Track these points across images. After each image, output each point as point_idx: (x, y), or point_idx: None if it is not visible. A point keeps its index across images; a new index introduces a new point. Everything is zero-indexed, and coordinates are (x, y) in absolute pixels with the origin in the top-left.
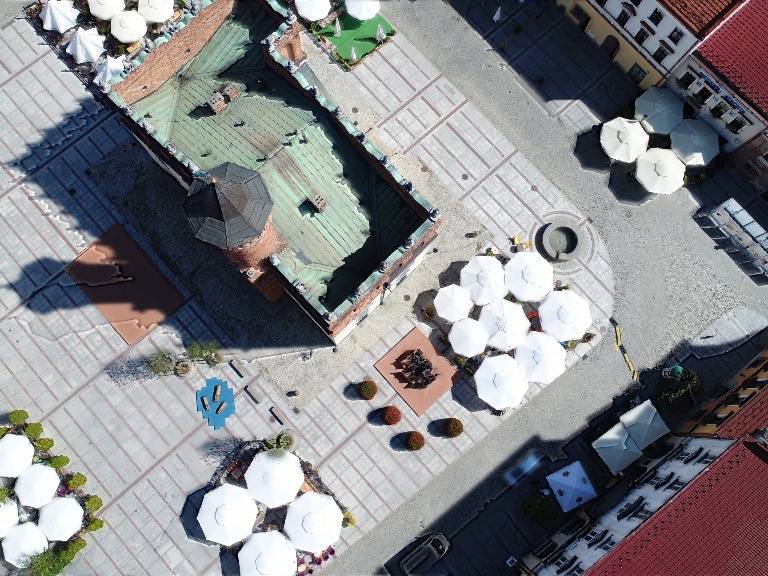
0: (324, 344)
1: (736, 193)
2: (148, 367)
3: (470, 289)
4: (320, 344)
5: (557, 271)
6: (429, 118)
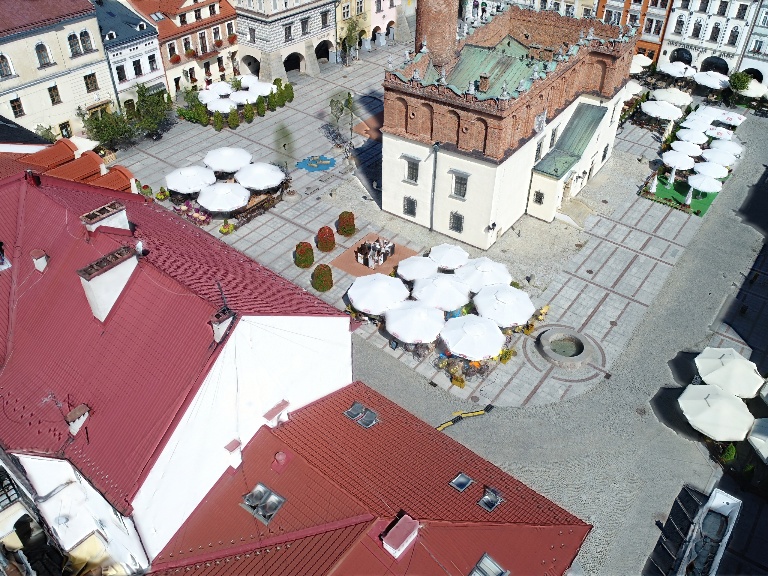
0: (381, 204)
1: (765, 542)
2: (336, 137)
3: (469, 262)
4: (380, 203)
5: (527, 350)
6: (633, 243)
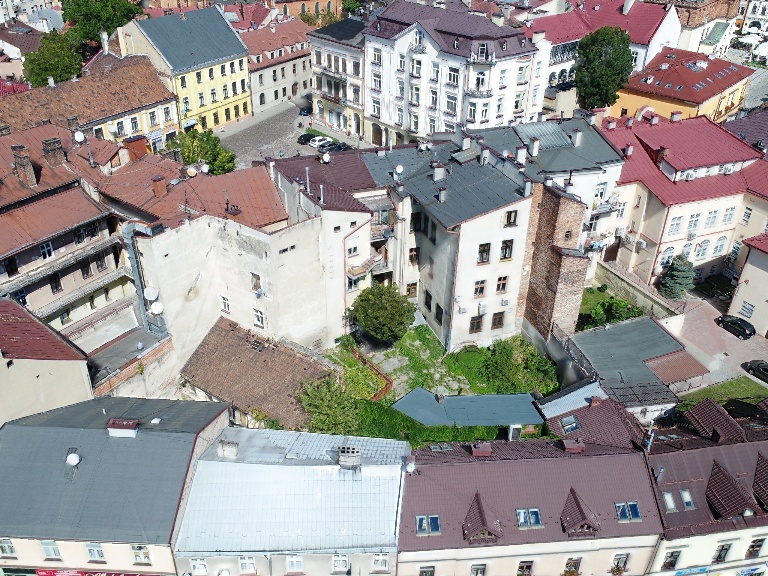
0: None
1: None
2: None
3: None
4: None
5: None
6: None
